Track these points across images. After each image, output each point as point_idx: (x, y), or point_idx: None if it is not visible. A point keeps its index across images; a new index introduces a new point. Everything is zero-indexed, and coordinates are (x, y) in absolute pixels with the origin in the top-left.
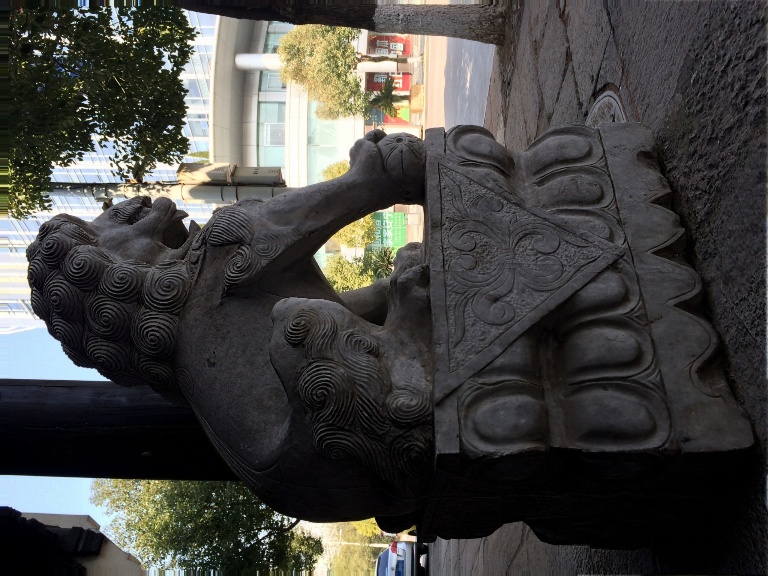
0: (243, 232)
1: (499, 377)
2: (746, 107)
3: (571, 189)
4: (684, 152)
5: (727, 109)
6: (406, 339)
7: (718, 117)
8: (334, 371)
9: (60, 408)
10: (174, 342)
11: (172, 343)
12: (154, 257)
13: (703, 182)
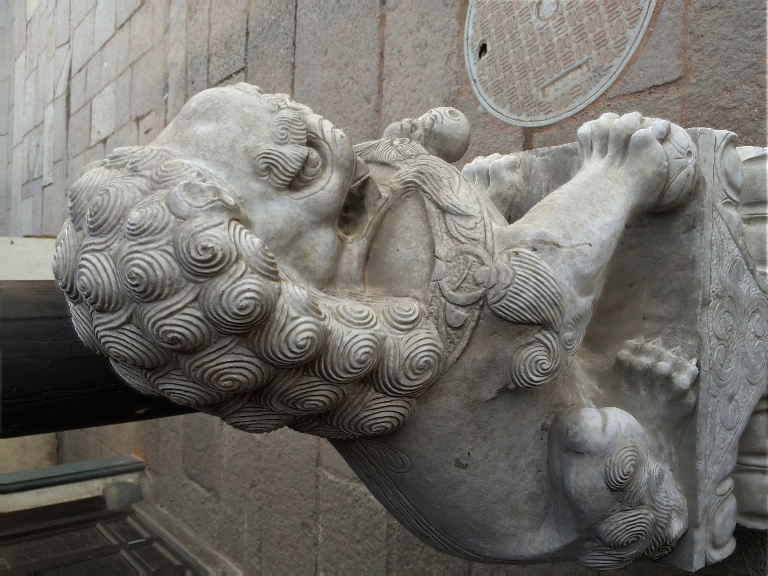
0: (554, 314)
1: (725, 483)
2: None
3: None
4: None
5: None
6: (664, 442)
7: None
8: (648, 519)
9: None
10: (399, 426)
11: None
12: (338, 263)
13: None
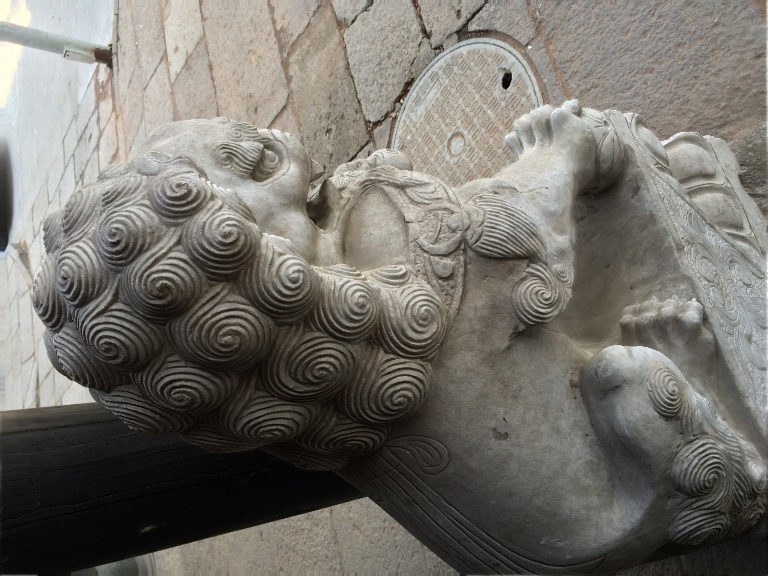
0: (536, 243)
1: None
2: None
3: (730, 211)
4: None
5: None
6: (702, 388)
7: None
8: (718, 449)
9: None
10: (422, 402)
11: (420, 404)
12: (315, 247)
13: None
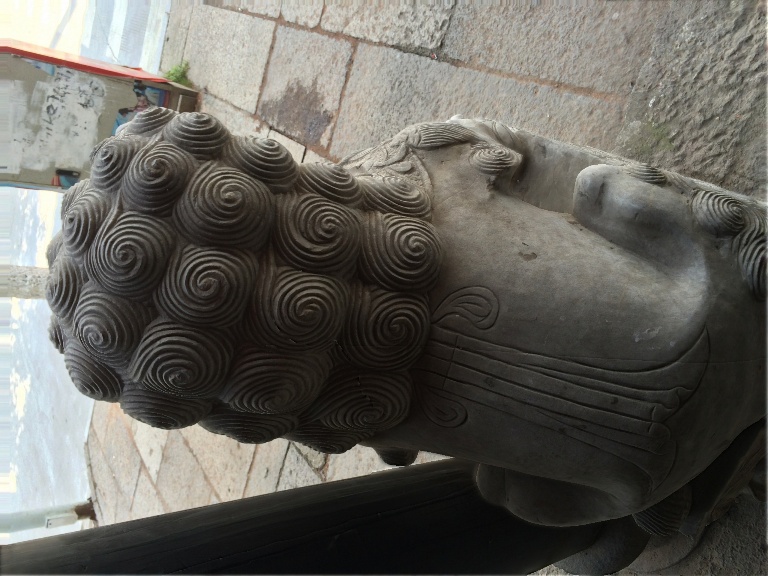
0: (468, 132)
1: None
2: (744, 80)
3: None
4: (666, 151)
5: (714, 96)
6: None
7: (708, 104)
8: None
9: (13, 575)
10: (441, 254)
11: (440, 255)
12: None
13: (713, 150)
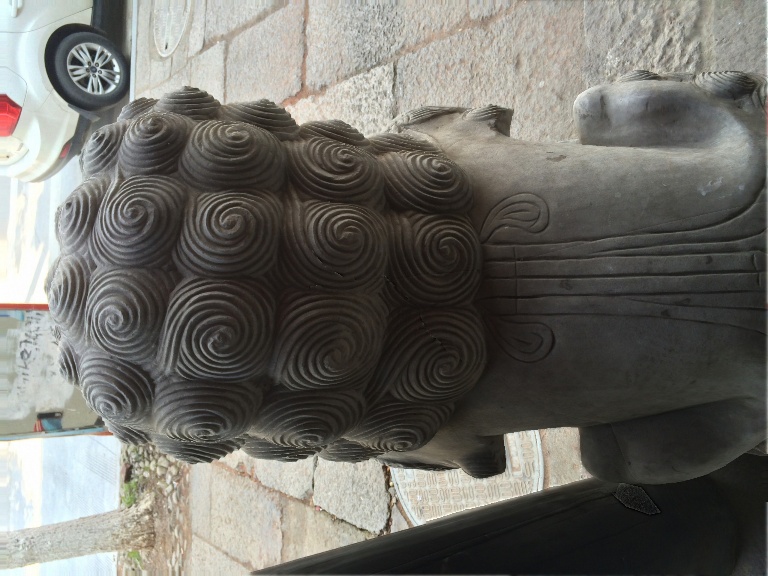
0: None
1: None
2: None
3: None
4: None
5: None
6: None
7: None
8: None
9: None
10: (468, 176)
11: None
12: None
13: None
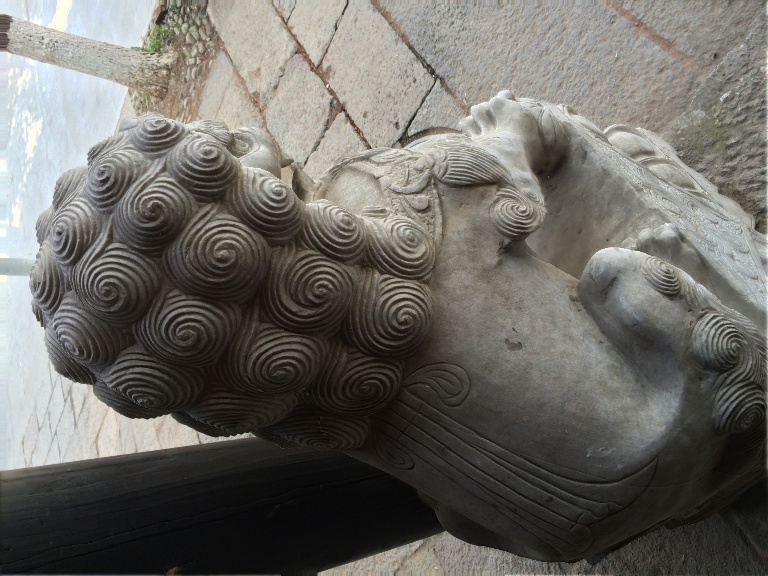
0: (499, 170)
1: None
2: None
3: (677, 174)
4: (718, 156)
5: None
6: None
7: None
8: (731, 321)
9: None
10: (429, 324)
11: (427, 326)
12: None
13: (764, 175)
